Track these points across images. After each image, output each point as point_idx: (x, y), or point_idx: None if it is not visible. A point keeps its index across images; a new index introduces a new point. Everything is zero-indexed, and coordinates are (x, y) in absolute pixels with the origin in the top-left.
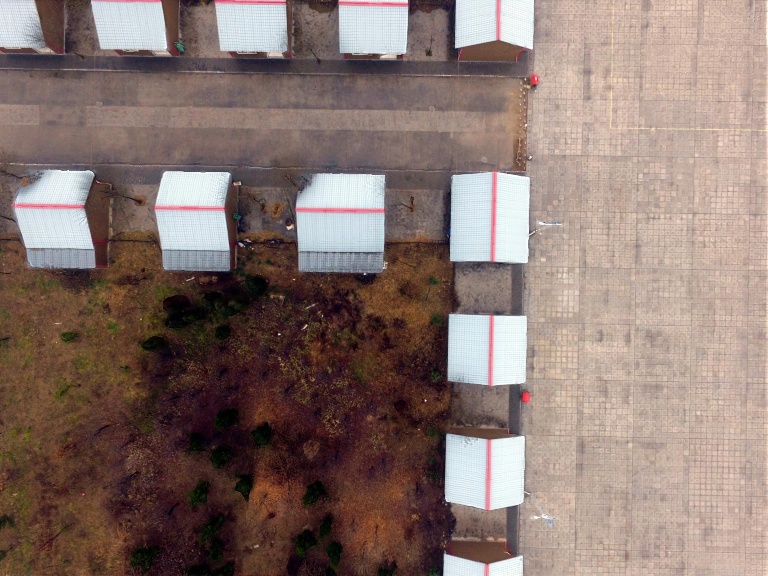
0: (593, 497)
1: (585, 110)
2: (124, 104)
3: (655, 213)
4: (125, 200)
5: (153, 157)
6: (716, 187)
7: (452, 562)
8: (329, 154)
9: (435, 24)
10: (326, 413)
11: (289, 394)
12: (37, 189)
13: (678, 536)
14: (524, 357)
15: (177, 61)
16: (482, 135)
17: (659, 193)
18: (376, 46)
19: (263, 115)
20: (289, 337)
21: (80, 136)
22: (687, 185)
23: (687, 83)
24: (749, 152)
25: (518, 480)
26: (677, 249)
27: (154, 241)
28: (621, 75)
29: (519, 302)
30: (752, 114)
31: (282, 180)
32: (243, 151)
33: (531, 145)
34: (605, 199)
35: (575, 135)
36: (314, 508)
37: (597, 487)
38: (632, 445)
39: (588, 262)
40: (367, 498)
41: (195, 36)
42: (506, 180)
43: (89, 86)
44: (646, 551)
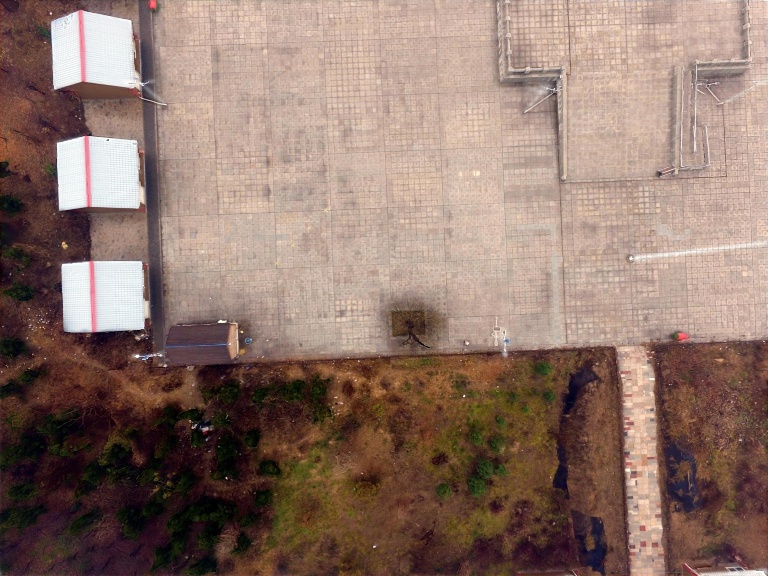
0: (231, 105)
1: None
2: None
3: None
4: None
5: None
6: None
7: (62, 148)
8: None
9: None
10: None
11: None
12: None
13: (318, 139)
14: None
15: None
16: None
17: None
18: None
19: None
20: None
21: None
22: None
23: None
24: None
25: (125, 63)
26: None
27: None
28: None
29: None
30: None
31: None
32: None
33: None
34: None
35: None
36: None
37: (234, 95)
38: (267, 51)
39: None
40: None
41: None
42: None
43: None
44: (287, 156)
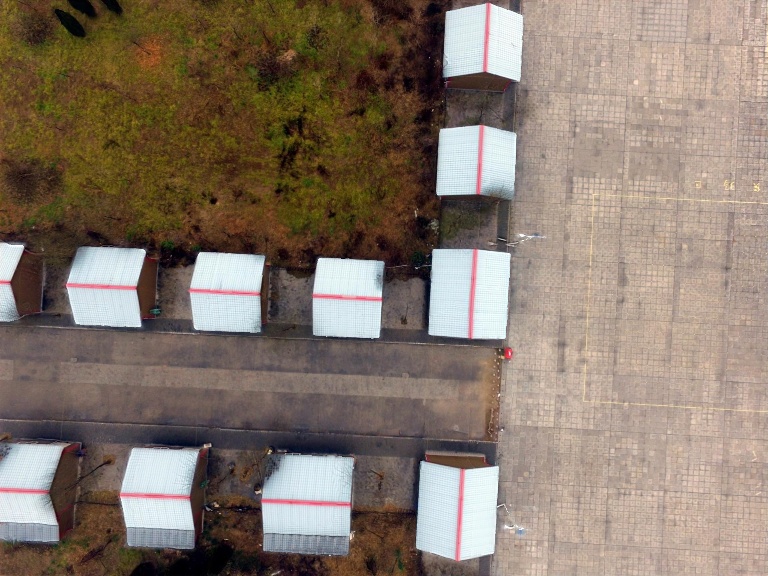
0: None
1: (558, 382)
2: (98, 361)
3: (626, 489)
4: (94, 459)
5: (125, 415)
6: (688, 465)
7: None
8: (301, 417)
9: (411, 292)
10: None
11: None
12: (3, 469)
13: None
14: None
15: (153, 322)
16: (455, 403)
17: (630, 469)
18: (349, 331)
19: (236, 376)
20: None
21: (53, 391)
22: (659, 462)
23: (661, 359)
24: (722, 431)
25: None
26: (647, 526)
27: (121, 505)
28: (595, 349)
29: (486, 575)
30: (726, 393)
31: (253, 443)
32: (215, 411)
33: (503, 415)
34: (576, 473)
35: (548, 407)
36: None
37: None
38: None
39: (557, 536)
40: None
41: (172, 297)
42: (474, 475)
43: (64, 342)
44: None
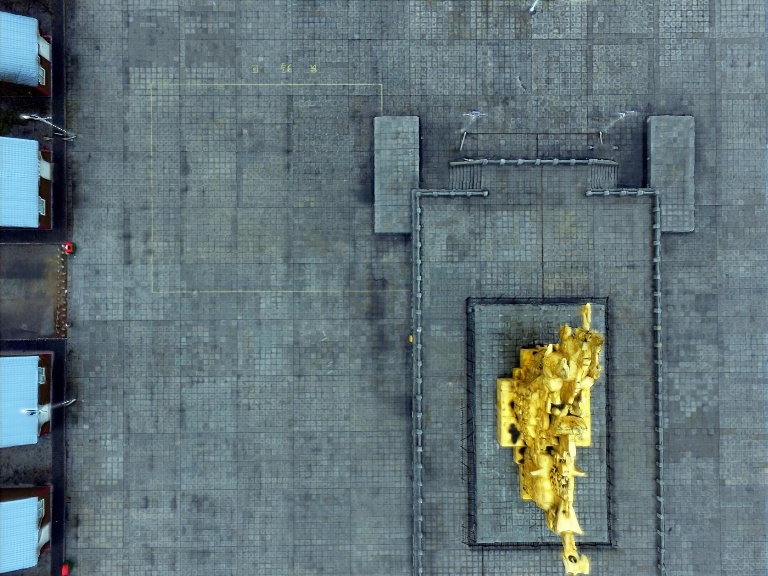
0: None
1: (126, 275)
2: None
3: (199, 377)
4: None
5: None
6: (259, 349)
7: None
8: None
9: None
10: None
11: None
12: None
13: None
14: (34, 540)
15: None
16: (22, 302)
17: (202, 356)
18: None
19: None
20: None
21: None
22: (230, 348)
23: (228, 246)
24: (291, 313)
25: None
26: (221, 412)
27: None
28: (161, 239)
29: (60, 471)
30: (293, 275)
31: None
32: None
33: (72, 311)
34: (148, 364)
35: (116, 300)
36: None
37: None
38: None
39: (132, 428)
40: None
41: None
42: (1, 364)
43: None
44: None
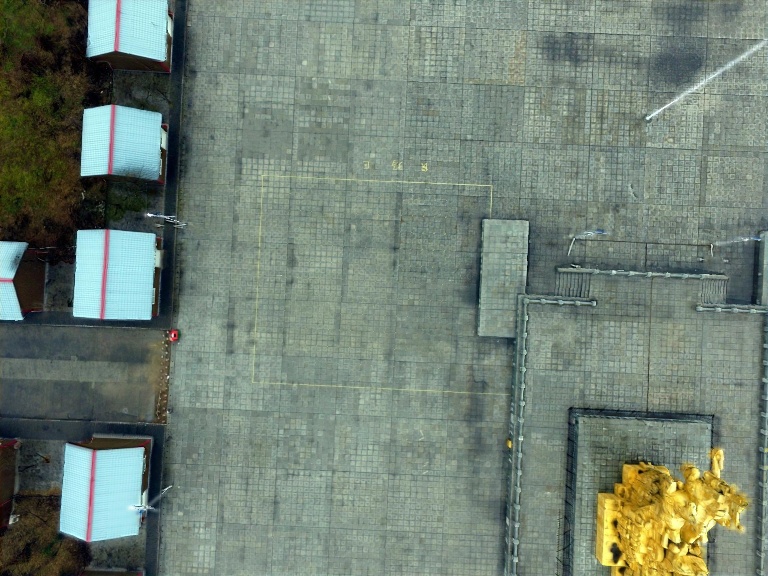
0: None
1: (227, 364)
2: None
3: (295, 469)
4: None
5: None
6: (356, 445)
7: None
8: None
9: None
10: None
11: None
12: None
13: None
14: None
15: None
16: (124, 385)
17: (299, 449)
18: None
19: None
20: None
21: None
22: (327, 442)
23: (330, 340)
24: (390, 411)
25: None
26: (315, 507)
27: None
28: (265, 330)
29: (153, 557)
30: (394, 373)
31: None
32: None
33: (172, 397)
34: (245, 454)
35: (217, 388)
36: None
37: None
38: None
39: (225, 517)
40: None
41: None
42: (110, 456)
43: None
44: None
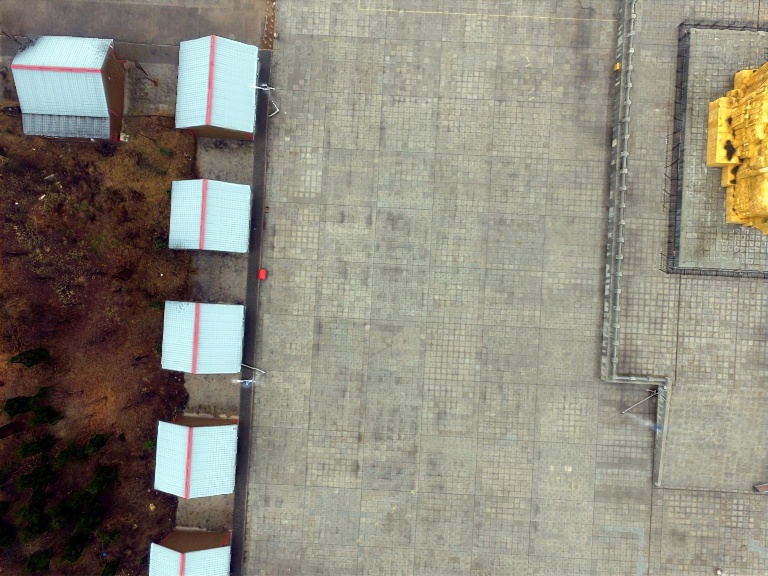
0: (328, 378)
1: None
2: None
3: (400, 96)
4: None
5: None
6: (462, 72)
7: (164, 428)
8: (75, 25)
9: None
10: (60, 283)
11: (23, 263)
12: None
13: (412, 419)
14: (246, 226)
15: None
16: (230, 12)
17: (405, 76)
18: None
19: None
20: (26, 206)
21: None
22: (433, 69)
23: None
24: (496, 38)
25: (234, 349)
26: (421, 132)
27: None
28: None
29: (261, 180)
30: None
31: None
32: None
33: (279, 23)
34: (351, 80)
35: (323, 15)
36: (44, 378)
37: (333, 368)
38: (369, 327)
39: (332, 143)
40: (98, 370)
41: None
42: (227, 45)
43: None
44: (379, 433)
